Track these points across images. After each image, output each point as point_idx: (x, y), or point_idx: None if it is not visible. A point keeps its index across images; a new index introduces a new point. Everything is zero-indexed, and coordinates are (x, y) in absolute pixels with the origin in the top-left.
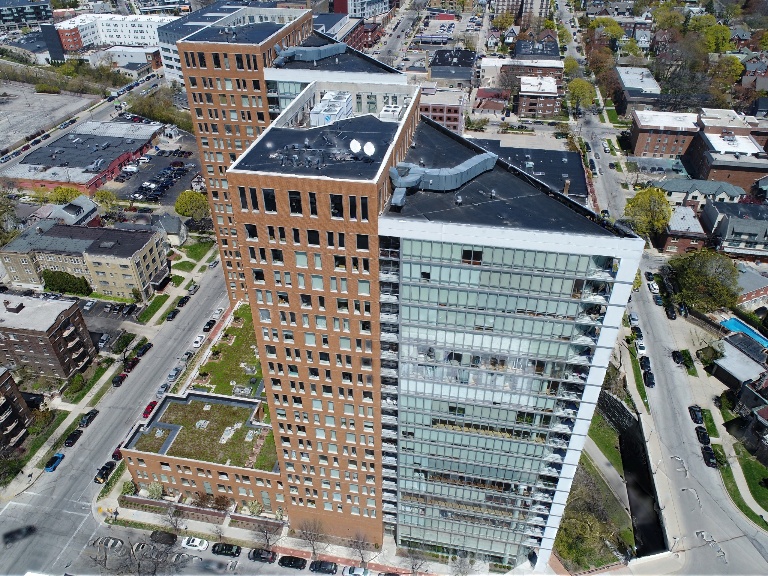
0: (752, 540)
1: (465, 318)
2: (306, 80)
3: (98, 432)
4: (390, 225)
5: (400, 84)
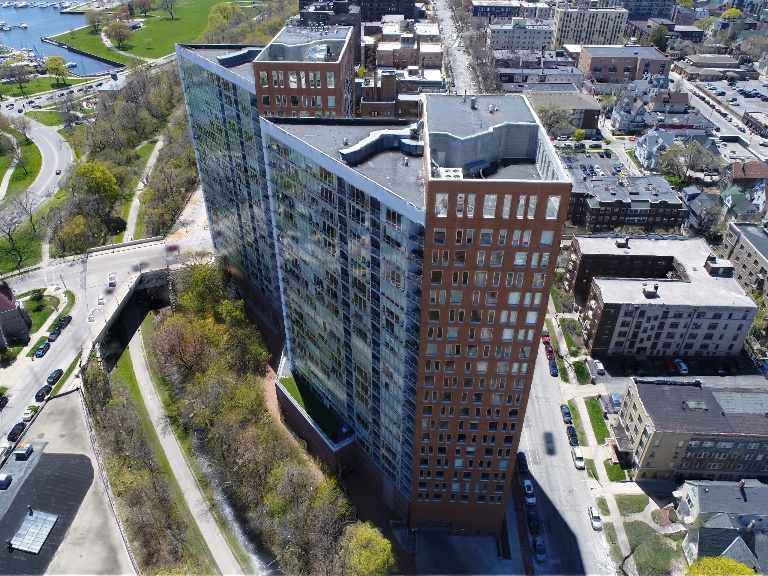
0: (84, 287)
1: None
2: None
3: None
4: None
5: (268, 61)
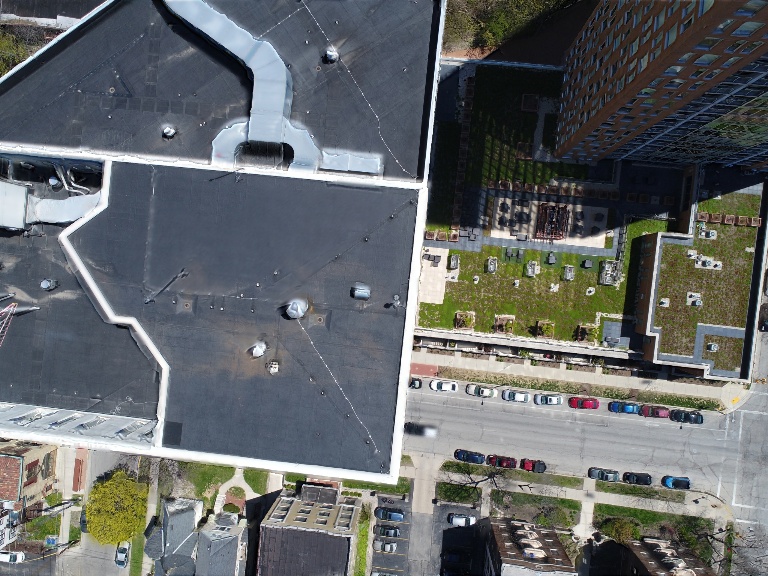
0: None
1: None
2: None
3: (625, 454)
4: None
5: None
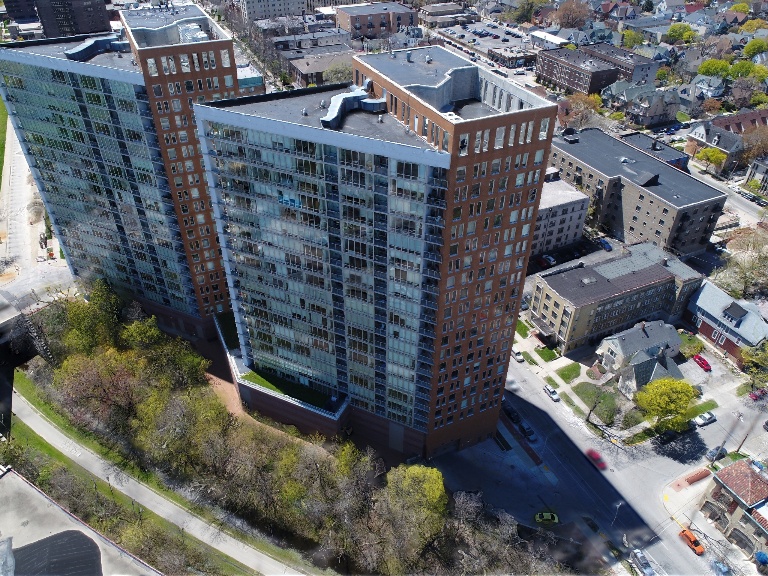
0: None
1: None
2: None
3: None
4: None
5: (155, 46)
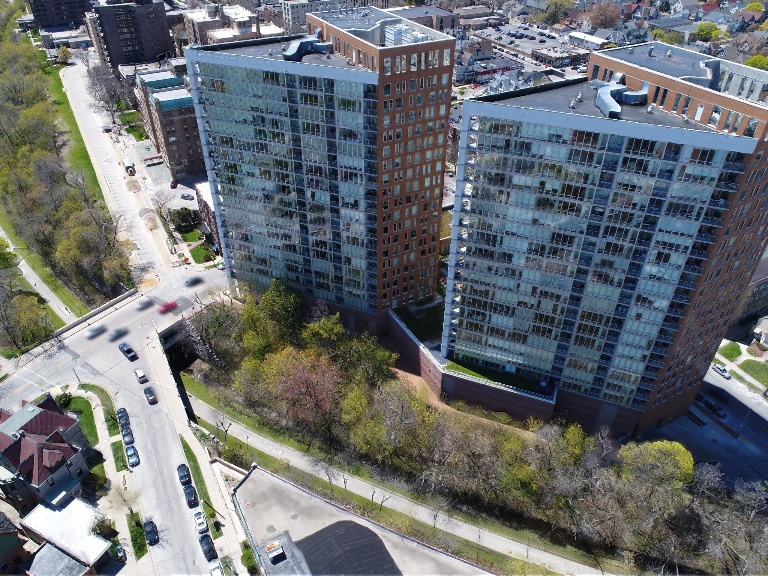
0: (98, 373)
1: None
2: None
3: None
4: None
5: (393, 46)
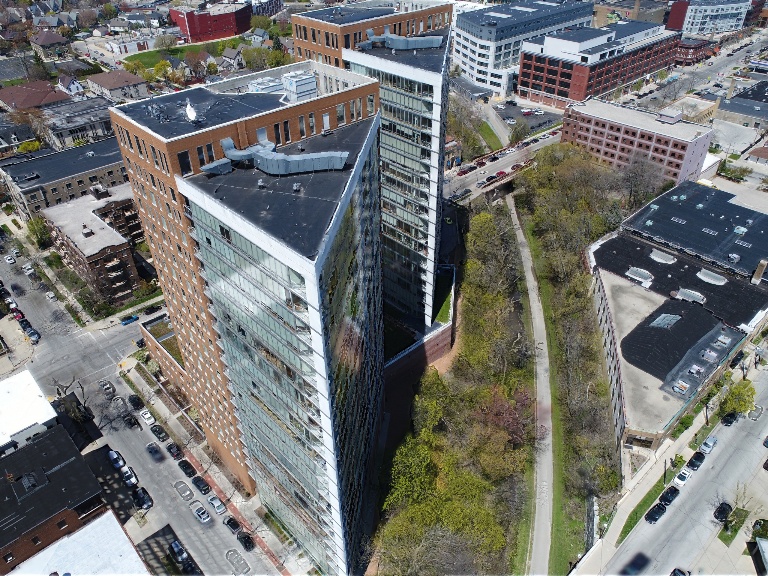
0: None
1: (238, 295)
2: (369, 65)
3: None
4: (181, 184)
5: None
